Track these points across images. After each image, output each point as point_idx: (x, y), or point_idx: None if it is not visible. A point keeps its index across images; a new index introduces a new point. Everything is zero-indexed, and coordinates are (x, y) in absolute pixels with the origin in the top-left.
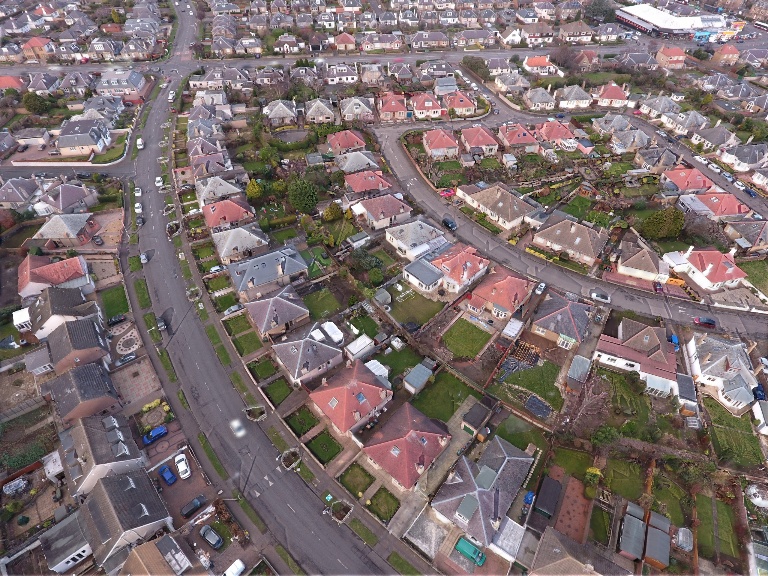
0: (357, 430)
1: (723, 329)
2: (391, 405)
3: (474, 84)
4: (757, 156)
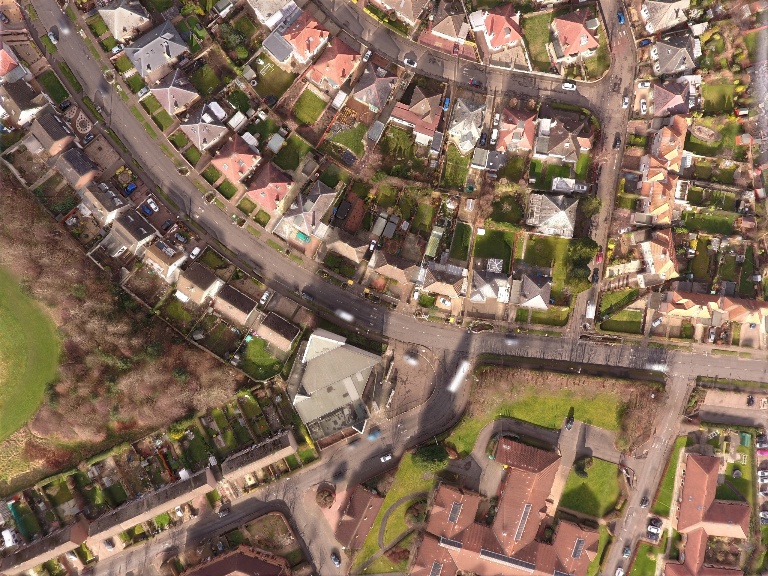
0: (243, 179)
1: (487, 88)
2: (262, 161)
3: None
4: None
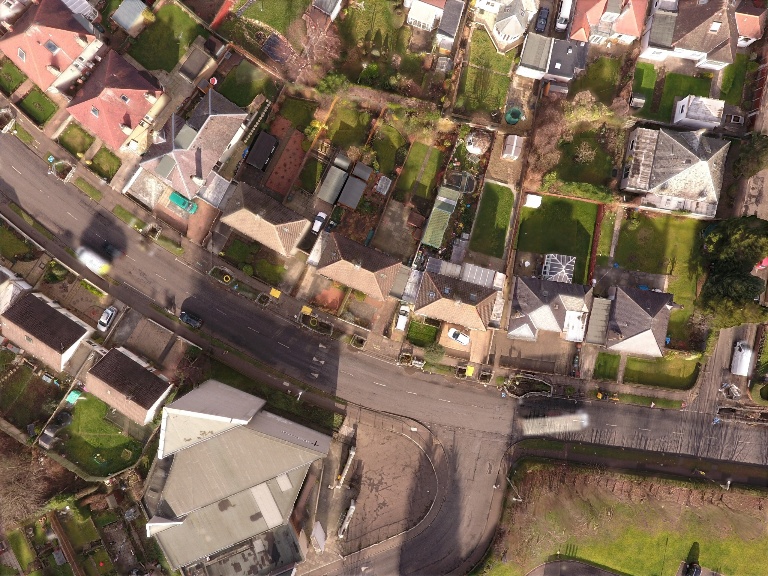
0: (68, 86)
1: None
2: (107, 52)
3: None
4: None
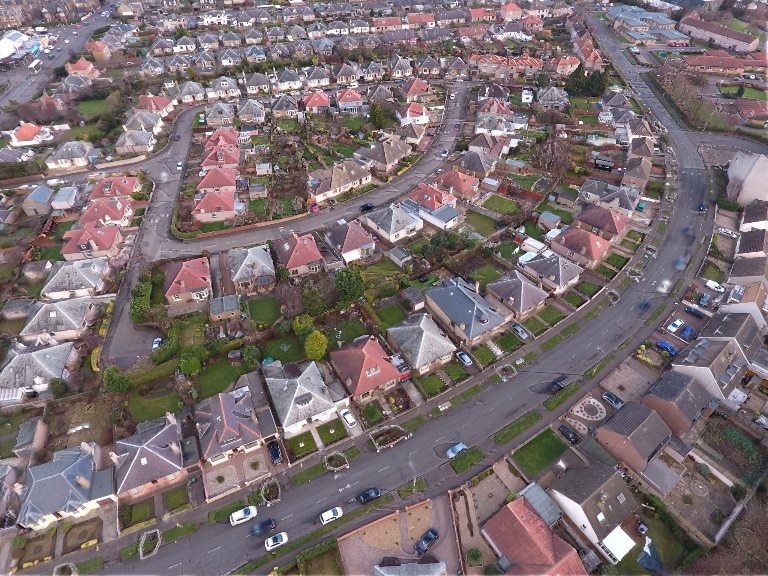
0: None
1: None
2: None
3: (52, 180)
4: (294, 74)
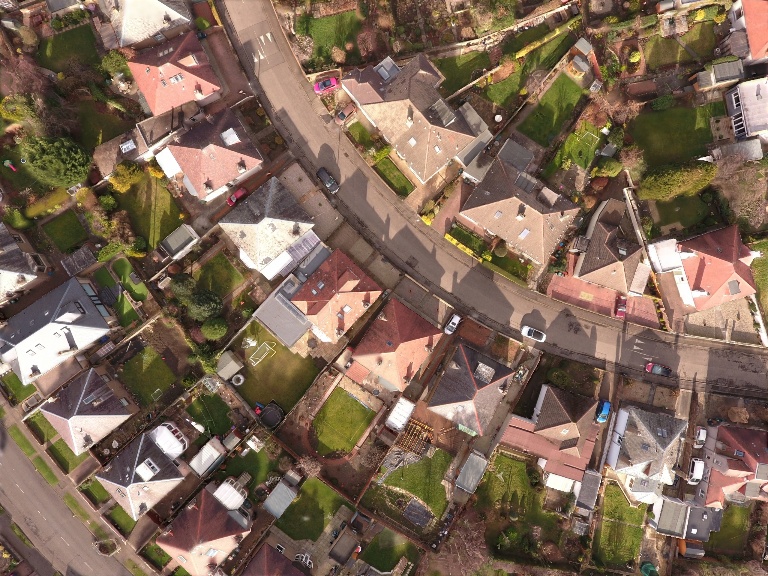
0: None
1: (678, 376)
2: (254, 524)
3: None
4: None
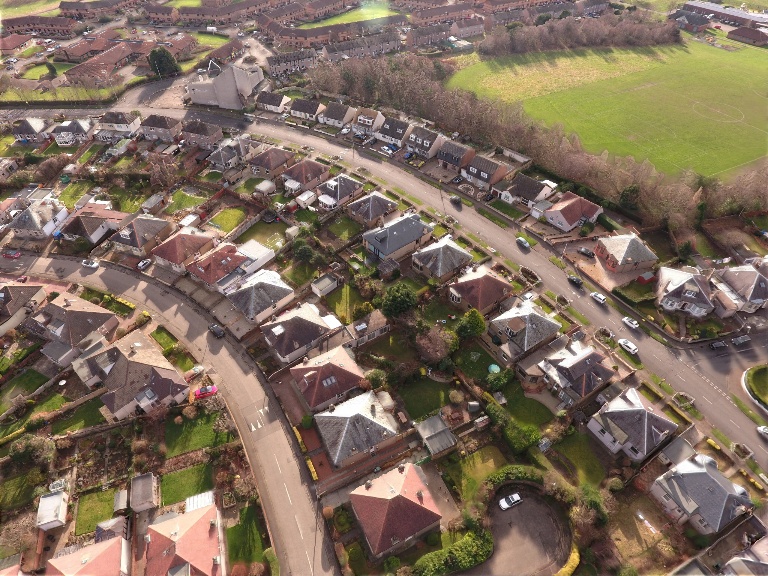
0: None
1: None
2: None
3: None
4: None
